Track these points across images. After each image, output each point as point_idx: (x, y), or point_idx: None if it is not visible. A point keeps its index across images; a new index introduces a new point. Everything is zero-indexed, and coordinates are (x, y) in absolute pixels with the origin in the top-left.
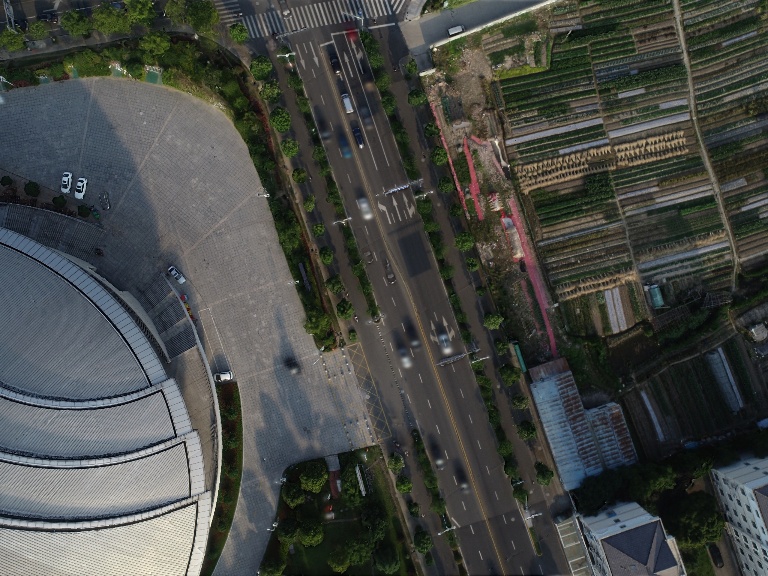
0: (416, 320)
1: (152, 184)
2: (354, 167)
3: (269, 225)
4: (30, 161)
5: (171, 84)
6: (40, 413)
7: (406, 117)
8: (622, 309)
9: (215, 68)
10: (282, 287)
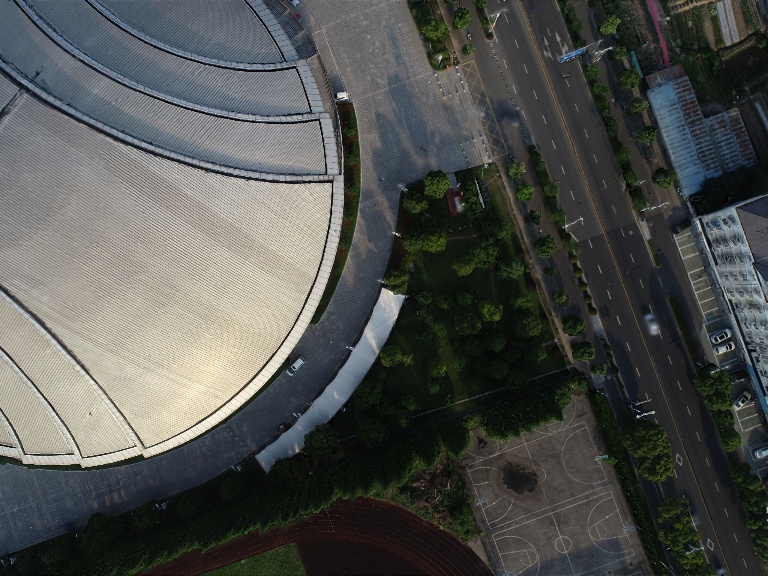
0: (529, 36)
1: None
2: None
3: None
4: None
5: None
6: (187, 64)
7: None
8: (734, 21)
9: None
10: (395, 7)
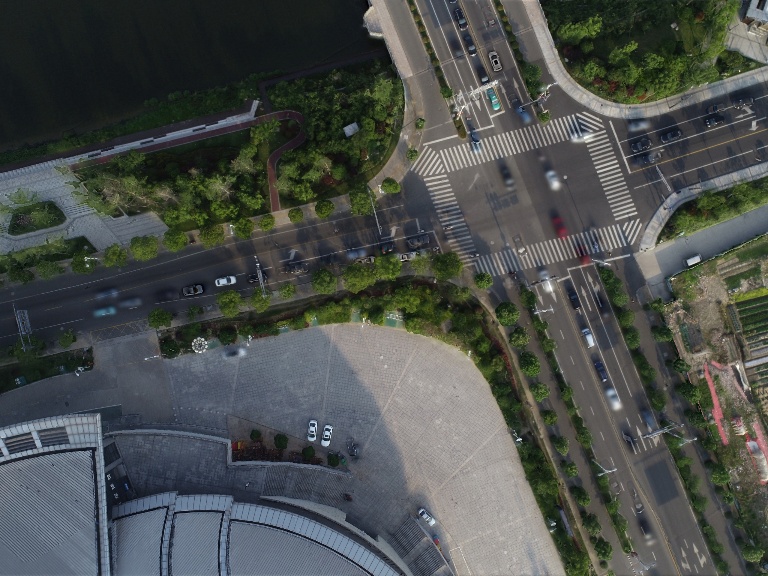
0: (667, 548)
1: (396, 427)
2: (597, 399)
3: (515, 461)
4: (274, 410)
5: (416, 332)
6: None
7: (646, 347)
8: None
9: (454, 310)
10: (531, 522)
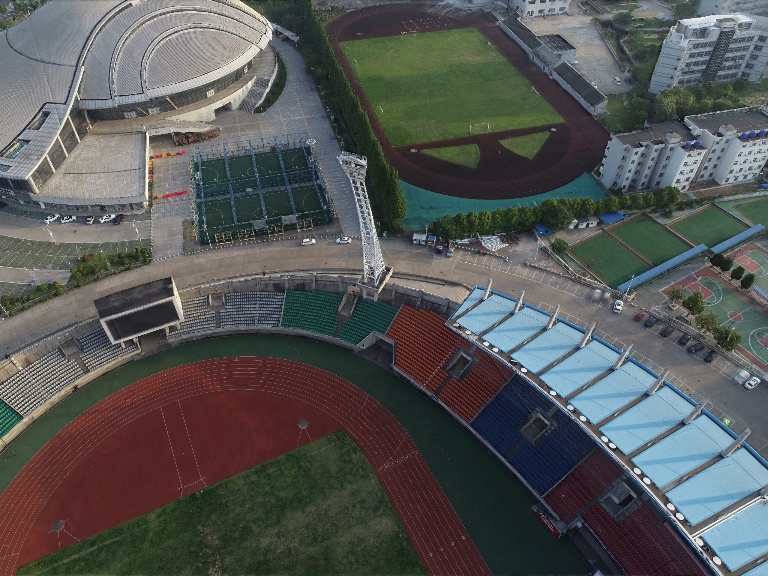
0: None
1: None
2: None
3: None
4: None
5: (10, 25)
6: None
7: None
8: None
9: None
10: None
